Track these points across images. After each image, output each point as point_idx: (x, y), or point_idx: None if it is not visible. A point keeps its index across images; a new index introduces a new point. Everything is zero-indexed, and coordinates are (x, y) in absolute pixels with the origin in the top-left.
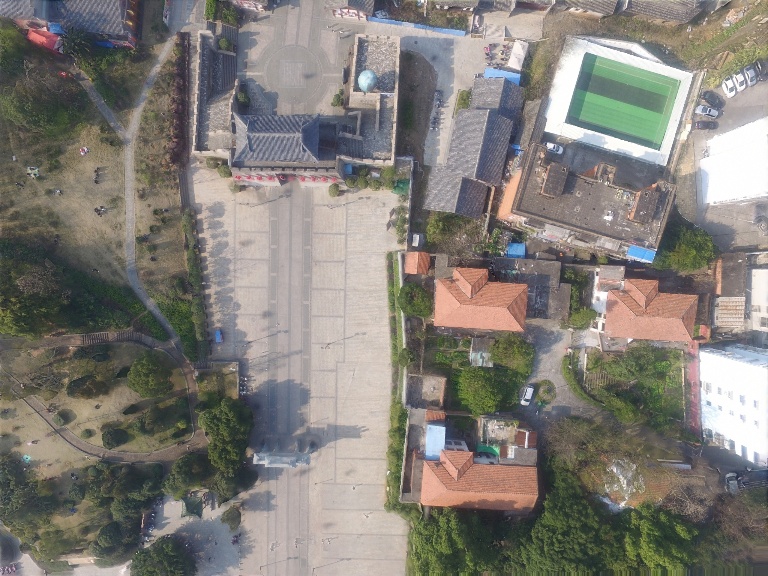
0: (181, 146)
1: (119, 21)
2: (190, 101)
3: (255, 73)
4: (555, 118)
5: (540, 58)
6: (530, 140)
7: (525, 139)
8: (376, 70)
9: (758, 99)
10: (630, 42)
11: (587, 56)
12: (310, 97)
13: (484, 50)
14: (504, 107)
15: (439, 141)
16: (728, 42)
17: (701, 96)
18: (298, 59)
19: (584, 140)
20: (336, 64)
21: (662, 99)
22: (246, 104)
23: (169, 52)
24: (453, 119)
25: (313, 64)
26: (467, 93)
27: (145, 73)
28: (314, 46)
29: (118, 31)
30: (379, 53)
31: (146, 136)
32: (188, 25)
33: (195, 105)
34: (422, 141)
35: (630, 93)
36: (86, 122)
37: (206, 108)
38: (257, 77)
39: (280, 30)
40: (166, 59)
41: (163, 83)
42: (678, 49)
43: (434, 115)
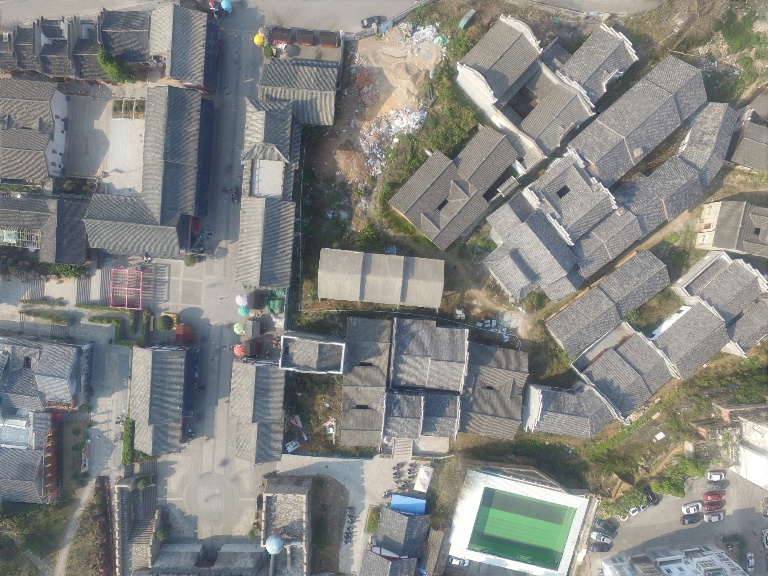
0: (108, 571)
1: (37, 496)
2: (114, 531)
3: (175, 499)
4: (458, 544)
5: (445, 480)
6: (434, 568)
7: (430, 566)
8: (285, 518)
9: (651, 519)
10: (529, 470)
11: (487, 488)
12: (228, 519)
13: (392, 469)
14: (409, 539)
15: (353, 551)
16: (627, 446)
17: (596, 523)
18: (215, 485)
19: (486, 562)
20: (251, 489)
21: (562, 512)
22: (168, 529)
23: (90, 495)
24: (365, 533)
25: (229, 490)
26: (376, 515)
27: (68, 517)
28: (230, 473)
29: (37, 501)
30: (287, 503)
31: (73, 572)
32: (107, 470)
33: (116, 551)
34: (337, 552)
35: (532, 508)
36: (15, 570)
37: (128, 547)
38: (177, 502)
39: (196, 459)
40: (87, 503)
41: (86, 524)
42: (581, 448)
43: (346, 531)
